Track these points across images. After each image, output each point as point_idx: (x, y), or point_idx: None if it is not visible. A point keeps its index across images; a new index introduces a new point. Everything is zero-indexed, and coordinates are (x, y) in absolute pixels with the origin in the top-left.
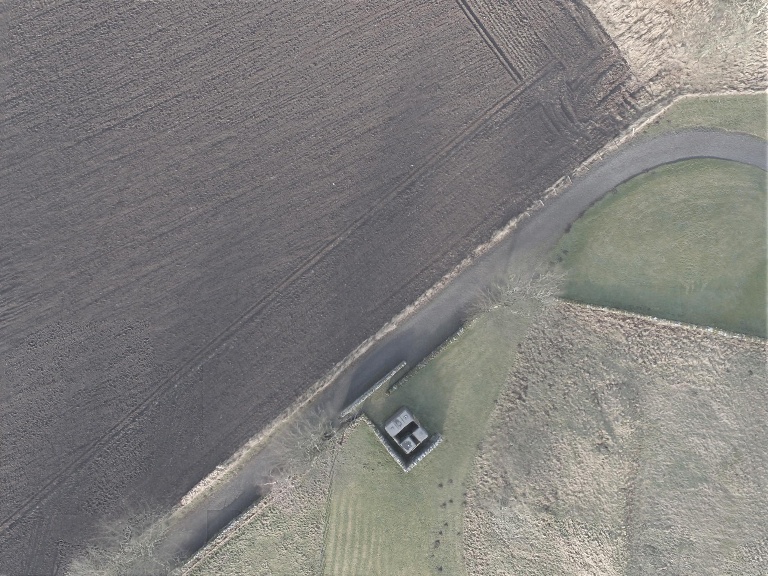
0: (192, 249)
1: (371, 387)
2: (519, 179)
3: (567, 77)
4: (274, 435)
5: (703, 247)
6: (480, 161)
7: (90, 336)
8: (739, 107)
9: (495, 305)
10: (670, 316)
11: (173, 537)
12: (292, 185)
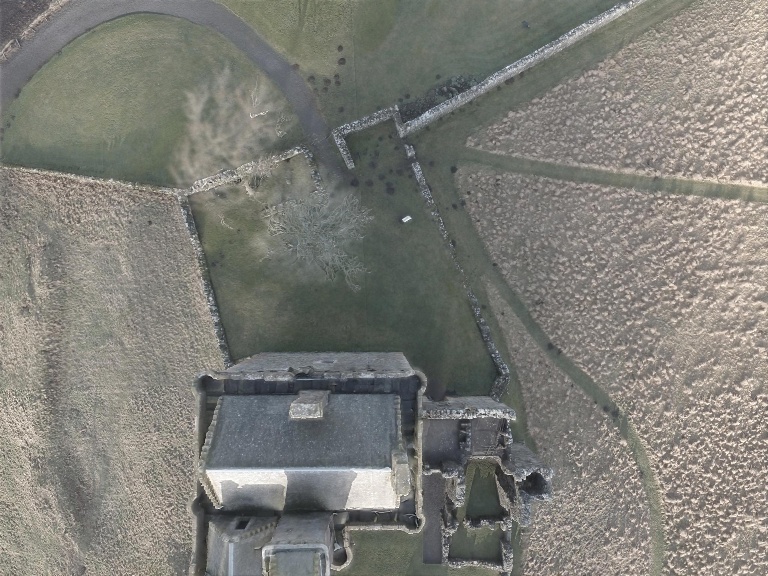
0: None
1: None
2: None
3: None
4: None
5: (124, 101)
6: None
7: None
8: None
9: None
10: (93, 173)
11: None
12: None
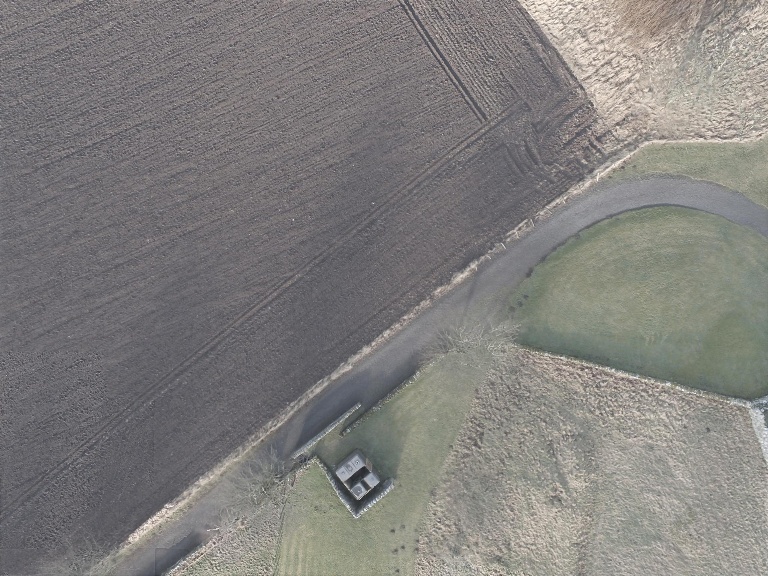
0: (148, 281)
1: (325, 428)
2: (481, 221)
3: (532, 118)
4: (225, 474)
5: (664, 298)
6: (442, 201)
7: (41, 367)
8: (706, 155)
9: (450, 351)
10: (629, 367)
11: (120, 574)
12: (251, 219)
